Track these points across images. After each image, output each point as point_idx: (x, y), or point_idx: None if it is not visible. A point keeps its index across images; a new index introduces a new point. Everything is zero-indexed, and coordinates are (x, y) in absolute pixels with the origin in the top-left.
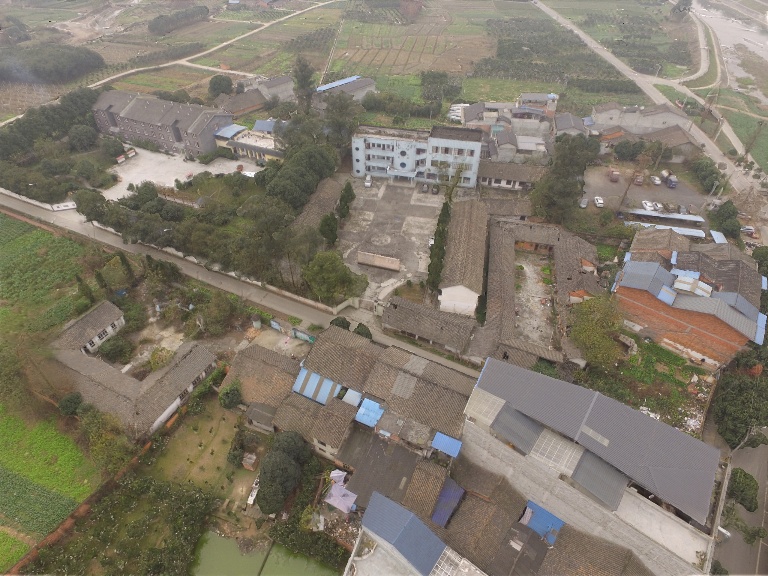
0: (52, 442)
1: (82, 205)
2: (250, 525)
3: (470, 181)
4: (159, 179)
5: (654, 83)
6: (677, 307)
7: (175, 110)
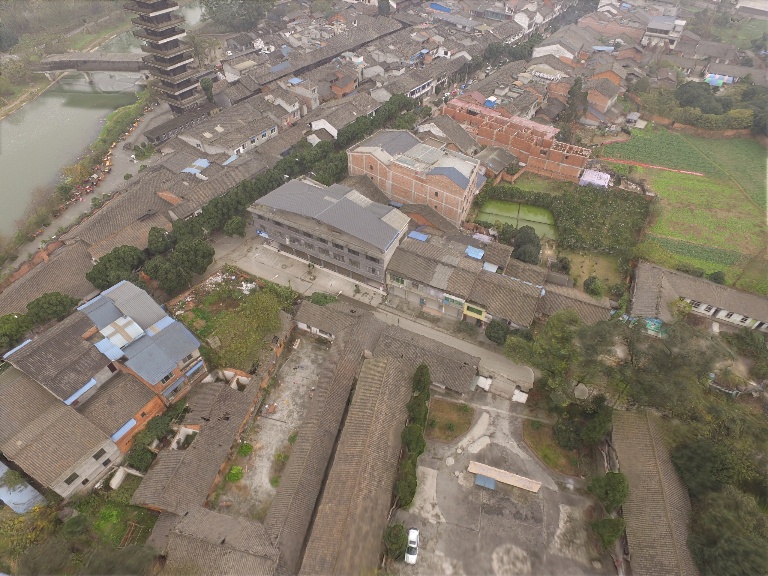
0: None
1: None
2: None
3: None
4: None
5: None
6: None
7: None
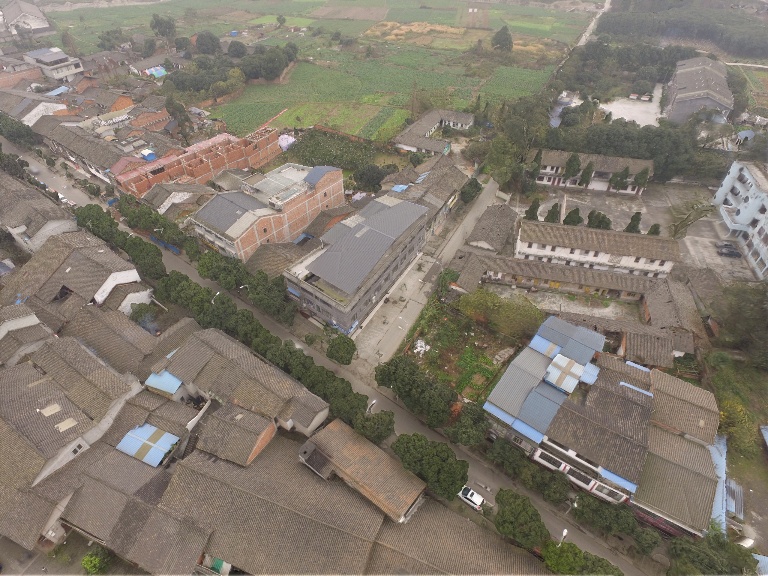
0: None
1: None
2: (353, 180)
3: None
4: (621, 115)
5: None
6: None
7: None
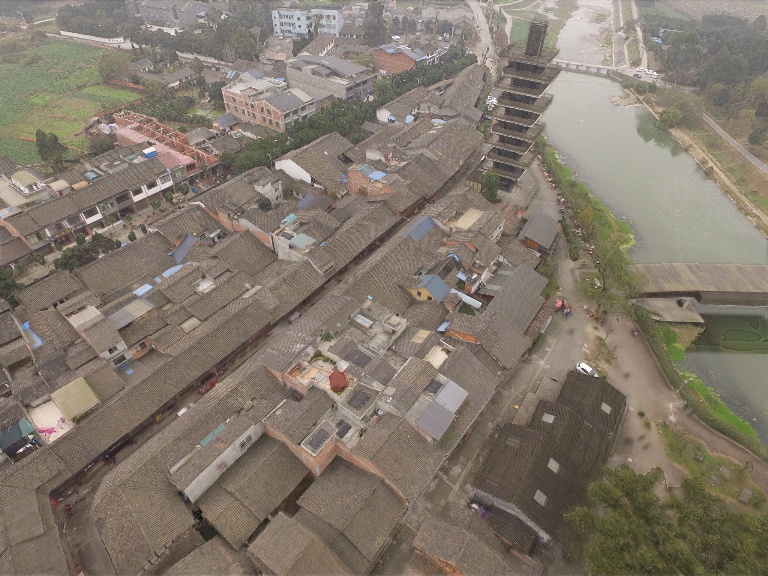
0: (128, 93)
1: (128, 31)
2: (206, 106)
3: (336, 36)
4: None
5: (482, 5)
6: (391, 53)
7: (174, 0)
